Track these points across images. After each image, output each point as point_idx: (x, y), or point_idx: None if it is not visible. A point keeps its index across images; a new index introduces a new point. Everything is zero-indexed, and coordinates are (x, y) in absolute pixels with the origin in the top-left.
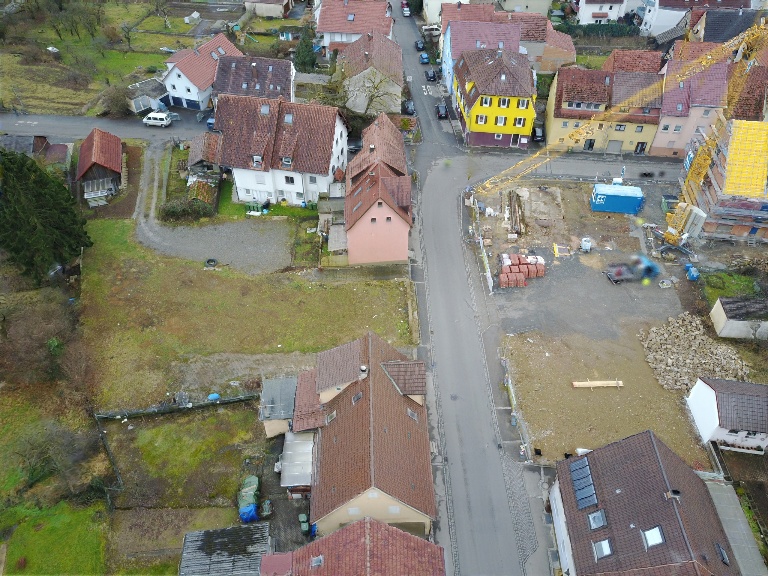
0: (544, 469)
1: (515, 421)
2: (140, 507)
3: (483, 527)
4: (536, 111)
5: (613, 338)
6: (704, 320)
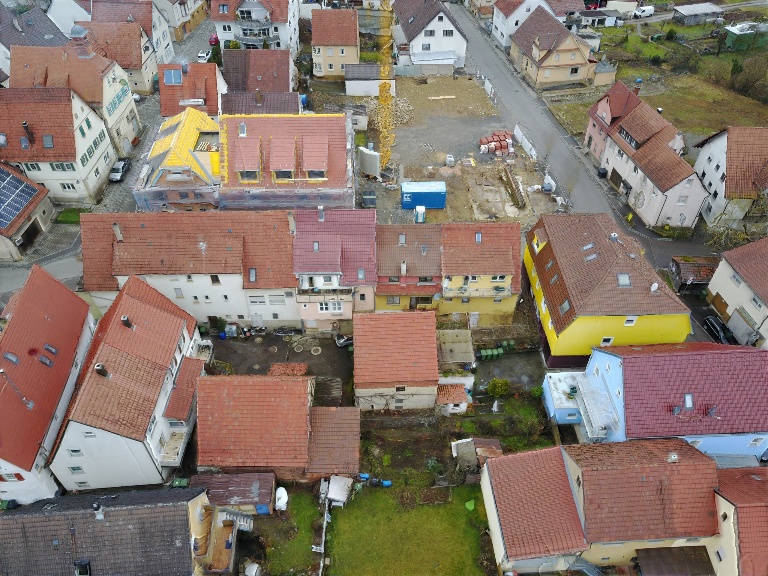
0: (467, 74)
1: (483, 84)
2: (632, 60)
3: (489, 61)
4: (528, 242)
5: (432, 117)
6: (373, 124)
